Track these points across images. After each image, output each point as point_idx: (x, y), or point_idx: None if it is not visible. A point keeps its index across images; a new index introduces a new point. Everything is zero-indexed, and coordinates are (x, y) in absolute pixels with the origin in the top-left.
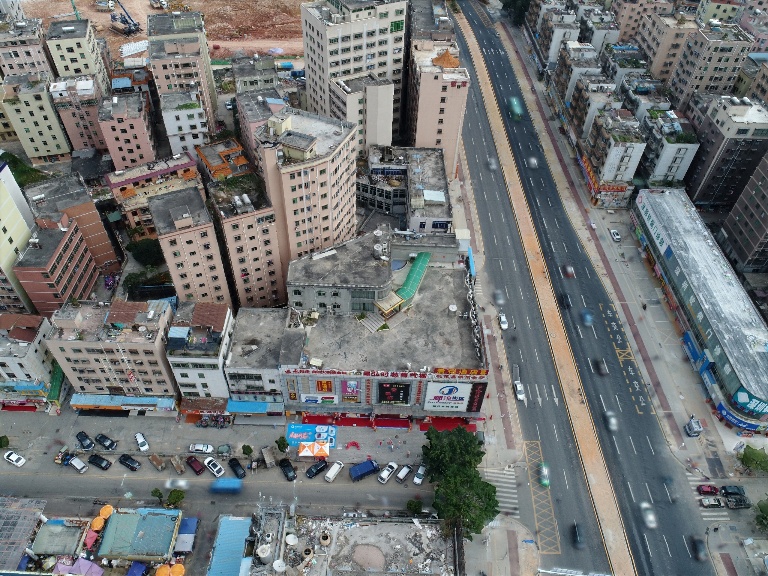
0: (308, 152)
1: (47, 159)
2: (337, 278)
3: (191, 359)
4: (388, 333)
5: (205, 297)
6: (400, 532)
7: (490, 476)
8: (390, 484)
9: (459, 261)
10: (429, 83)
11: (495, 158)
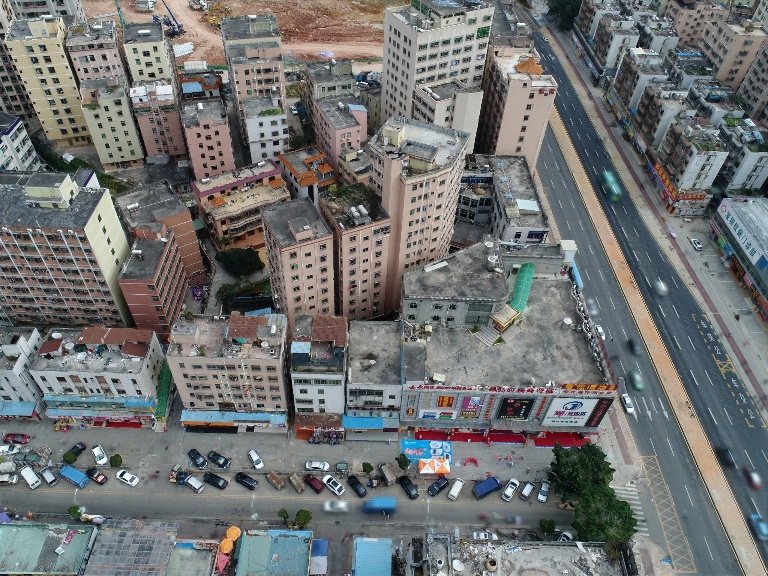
0: (431, 163)
1: (119, 165)
2: (454, 291)
3: (315, 375)
4: (504, 347)
5: (312, 310)
6: (564, 556)
7: None
8: (514, 502)
9: (561, 272)
10: (517, 90)
11: (564, 165)
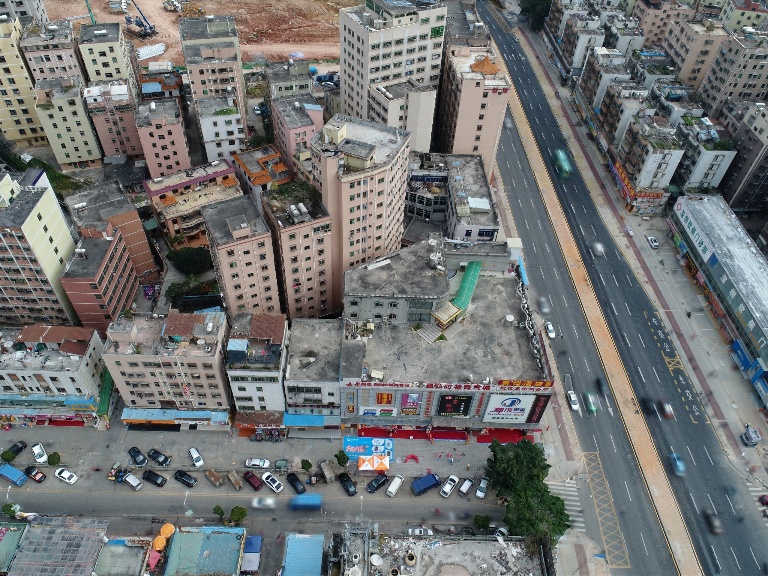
0: (368, 161)
1: (77, 165)
2: (395, 288)
3: (251, 372)
4: (446, 344)
5: (256, 308)
6: (485, 550)
7: (552, 489)
8: (452, 498)
9: (509, 270)
10: (470, 89)
11: (526, 164)
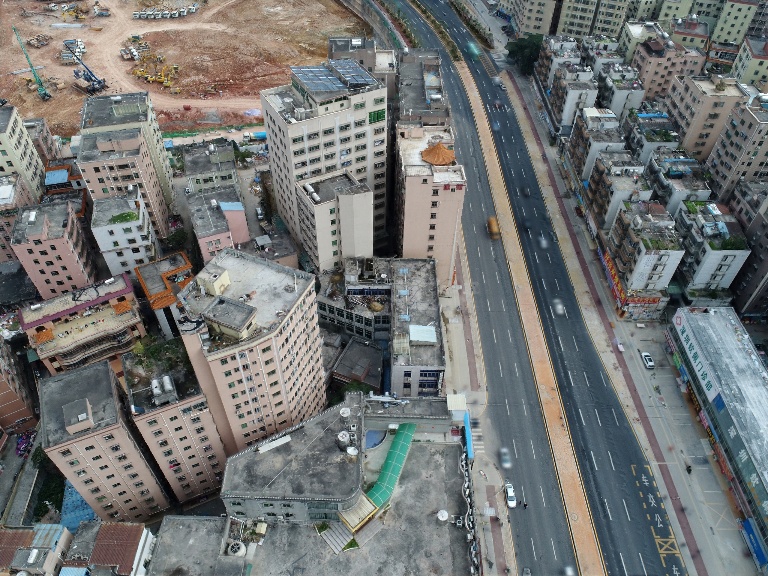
0: (244, 330)
1: None
2: (288, 484)
3: None
4: (357, 554)
5: (123, 495)
6: None
7: None
8: None
9: (453, 430)
10: (416, 187)
11: (500, 251)
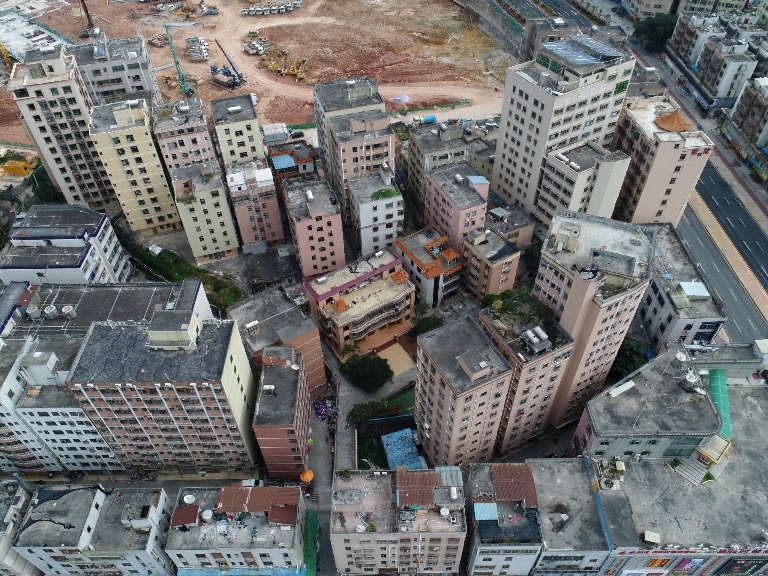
0: None
1: (212, 256)
2: (653, 423)
3: (507, 546)
4: (715, 485)
5: (474, 444)
6: None
7: None
8: None
9: (753, 375)
10: (667, 152)
11: (693, 218)
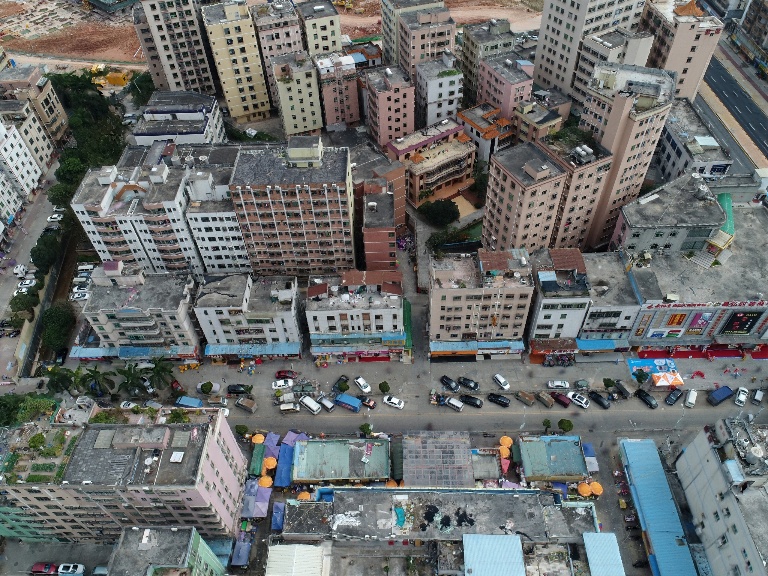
0: None
1: None
2: (674, 219)
3: (564, 300)
4: (721, 268)
5: (532, 247)
6: None
7: None
8: (747, 407)
9: (754, 200)
10: (684, 33)
11: (706, 107)
